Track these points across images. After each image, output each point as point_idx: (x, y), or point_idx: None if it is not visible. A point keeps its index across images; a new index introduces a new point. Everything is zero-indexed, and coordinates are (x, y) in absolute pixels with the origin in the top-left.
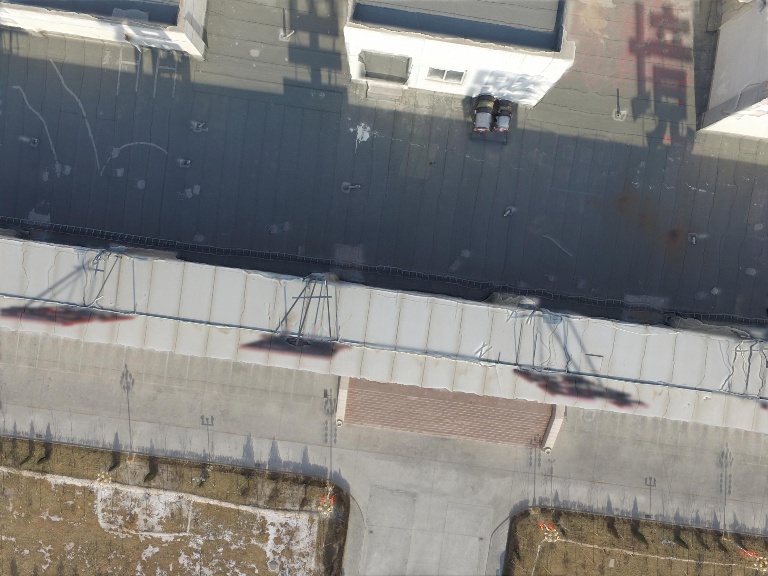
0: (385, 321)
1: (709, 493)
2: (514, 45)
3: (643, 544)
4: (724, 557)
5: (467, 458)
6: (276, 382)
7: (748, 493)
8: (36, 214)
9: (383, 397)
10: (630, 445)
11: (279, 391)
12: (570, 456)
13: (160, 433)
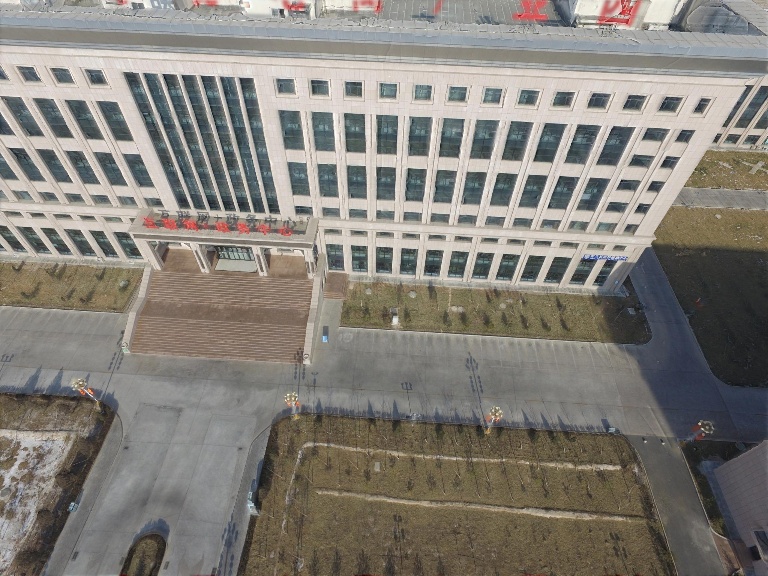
0: (68, 9)
1: (463, 393)
2: None
3: (407, 444)
4: (492, 452)
5: (237, 376)
6: (82, 327)
7: (499, 391)
8: None
9: (167, 323)
10: (385, 358)
11: (82, 333)
12: (331, 369)
13: None
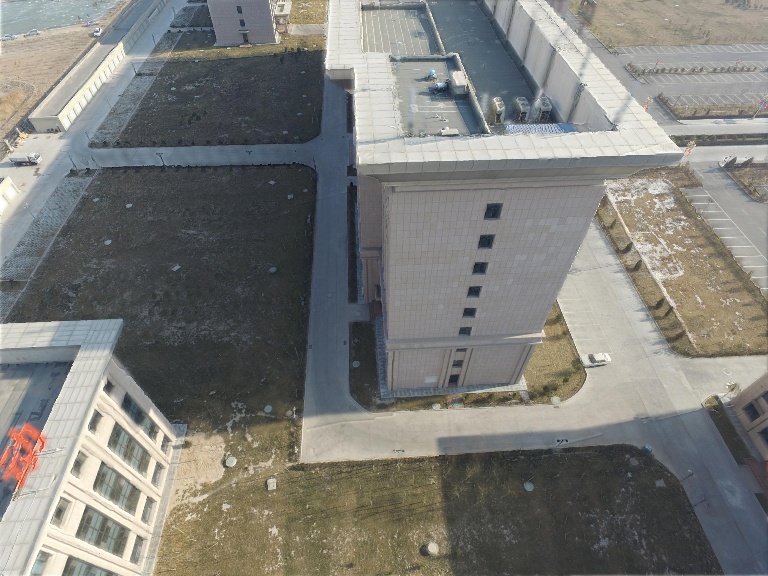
0: None
1: None
2: None
3: None
4: None
5: None
6: None
7: None
8: None
9: None
10: None
11: None
12: None
13: (599, 251)
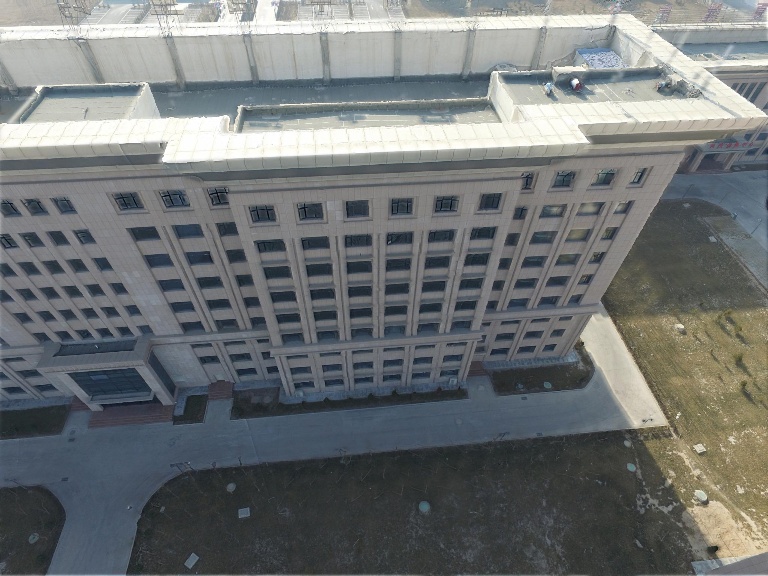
0: None
1: None
2: (67, 94)
3: None
4: None
5: None
6: None
7: None
8: (321, 89)
9: None
10: None
11: None
12: None
13: None
